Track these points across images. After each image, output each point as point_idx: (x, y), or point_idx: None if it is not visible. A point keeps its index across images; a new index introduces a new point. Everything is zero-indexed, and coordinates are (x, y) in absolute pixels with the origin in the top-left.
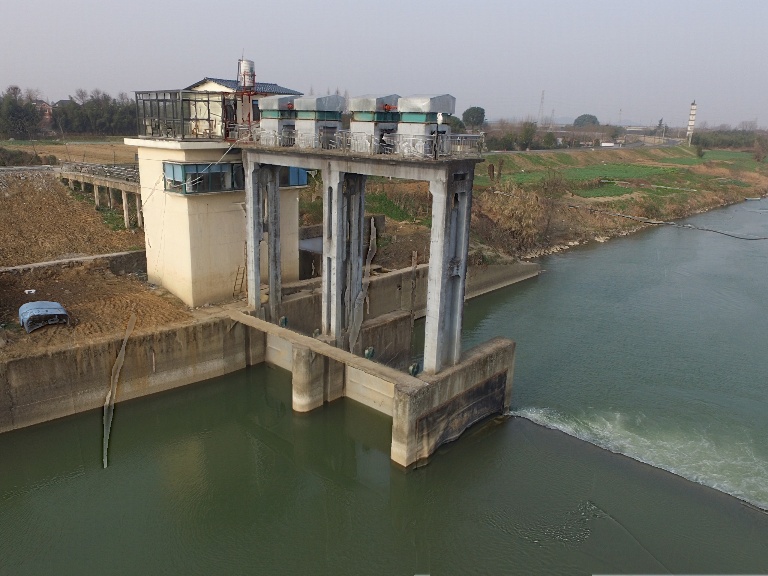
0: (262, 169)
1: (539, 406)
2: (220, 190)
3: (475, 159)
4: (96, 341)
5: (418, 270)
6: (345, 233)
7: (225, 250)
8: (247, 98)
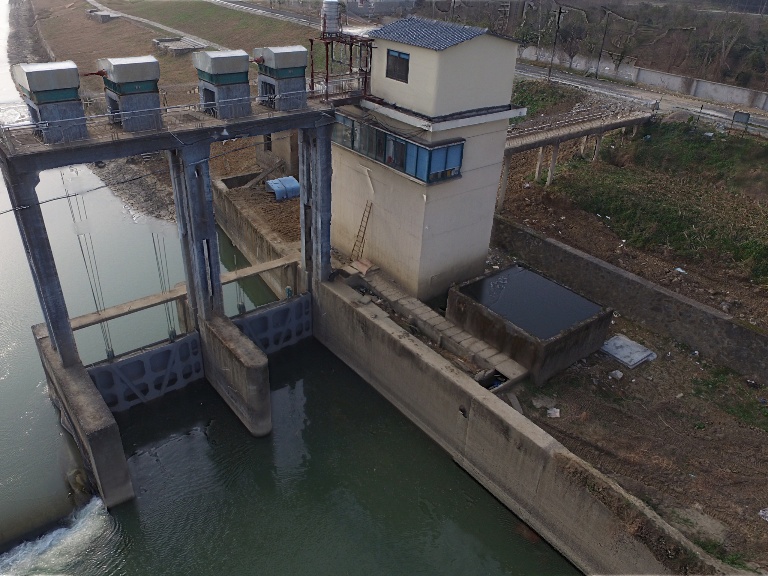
0: (380, 138)
1: (124, 574)
2: (342, 143)
3: (4, 151)
4: (246, 212)
5: (509, 425)
6: (181, 206)
7: (352, 208)
8: (383, 46)
